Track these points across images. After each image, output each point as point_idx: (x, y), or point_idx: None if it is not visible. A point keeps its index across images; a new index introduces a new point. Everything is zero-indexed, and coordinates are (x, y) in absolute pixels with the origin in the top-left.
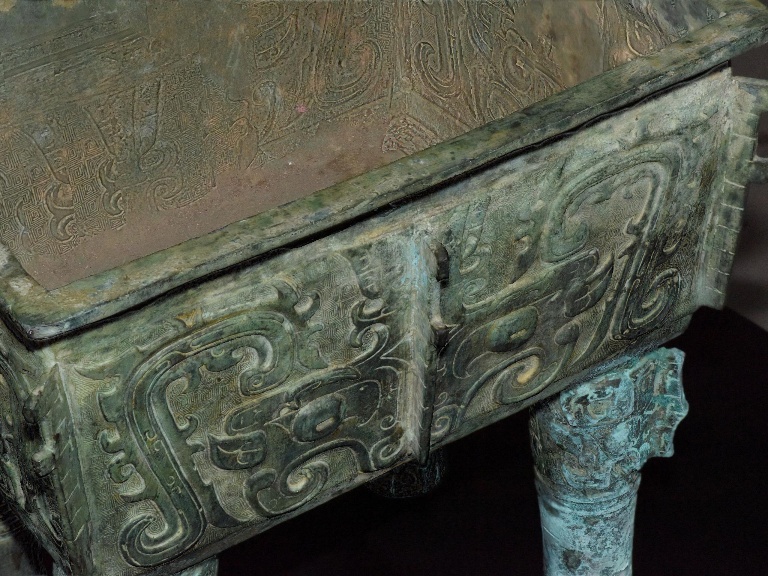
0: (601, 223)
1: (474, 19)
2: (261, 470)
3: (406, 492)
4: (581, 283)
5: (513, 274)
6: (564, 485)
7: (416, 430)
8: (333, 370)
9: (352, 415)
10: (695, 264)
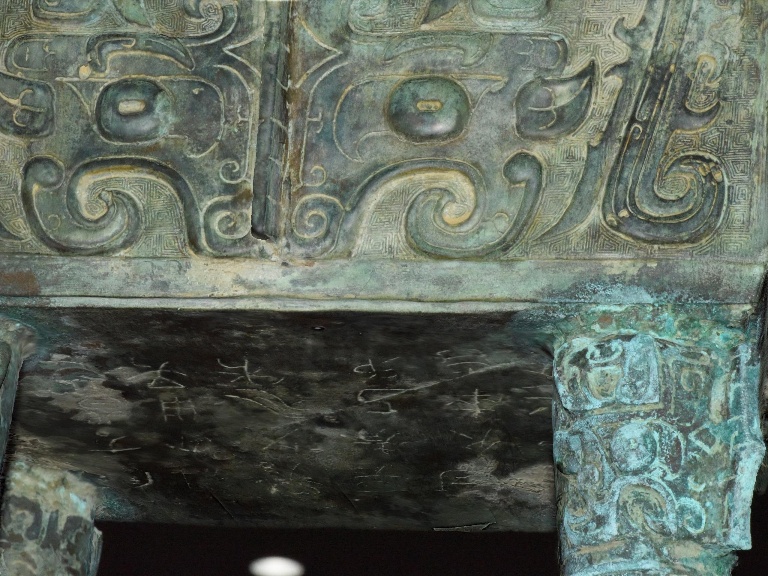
0: None
1: None
2: None
3: None
4: (537, 79)
5: (427, 12)
6: (571, 557)
7: None
8: None
9: (181, 133)
10: (755, 172)
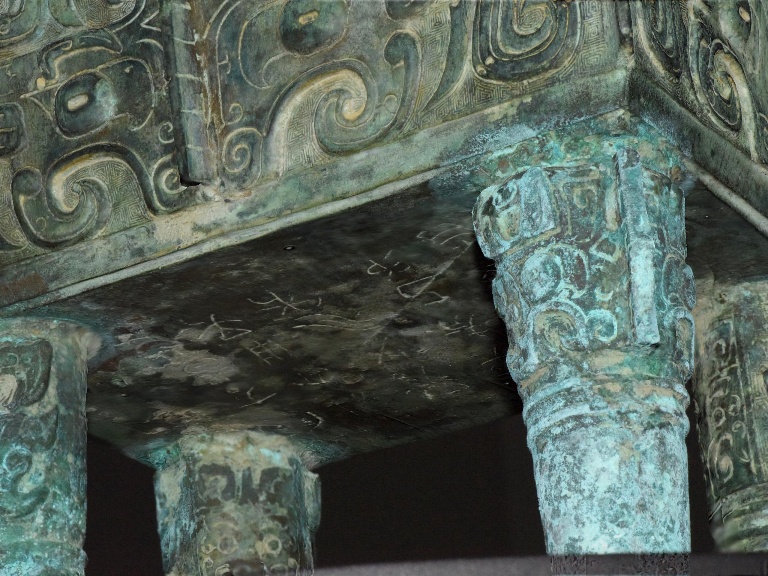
0: None
1: None
2: None
3: None
4: None
5: None
6: None
7: None
8: None
9: (124, 112)
10: None
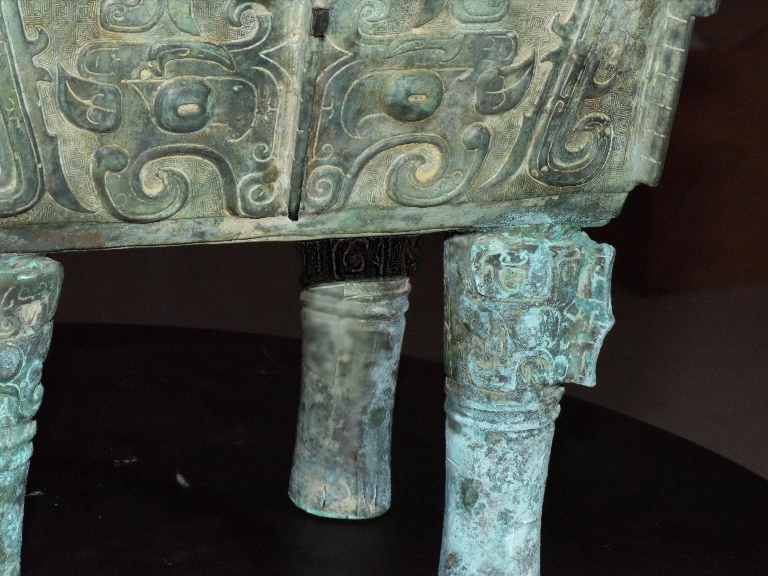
0: (523, 1)
1: None
2: (113, 145)
3: (337, 508)
4: (495, 70)
5: (418, 16)
6: (469, 386)
7: (290, 169)
8: (205, 42)
9: (222, 121)
10: (632, 124)
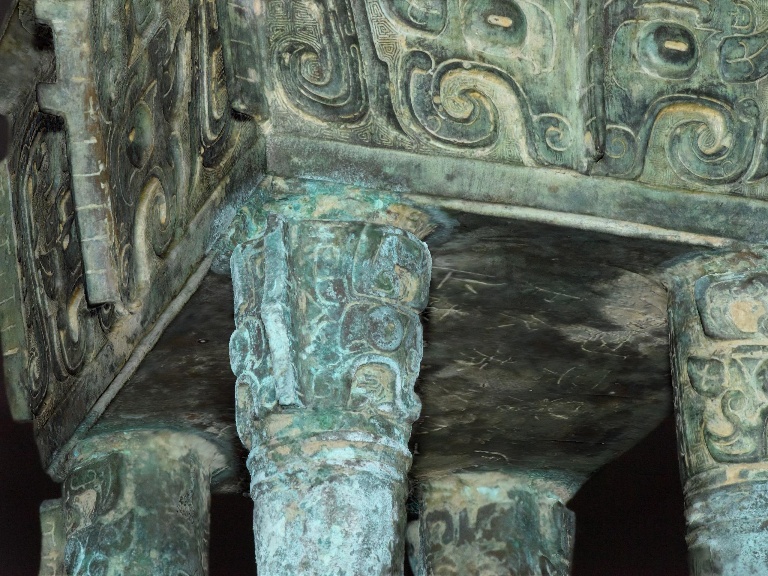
0: None
1: (767, 43)
2: None
3: None
4: None
5: None
6: None
7: None
8: None
9: None
10: None
